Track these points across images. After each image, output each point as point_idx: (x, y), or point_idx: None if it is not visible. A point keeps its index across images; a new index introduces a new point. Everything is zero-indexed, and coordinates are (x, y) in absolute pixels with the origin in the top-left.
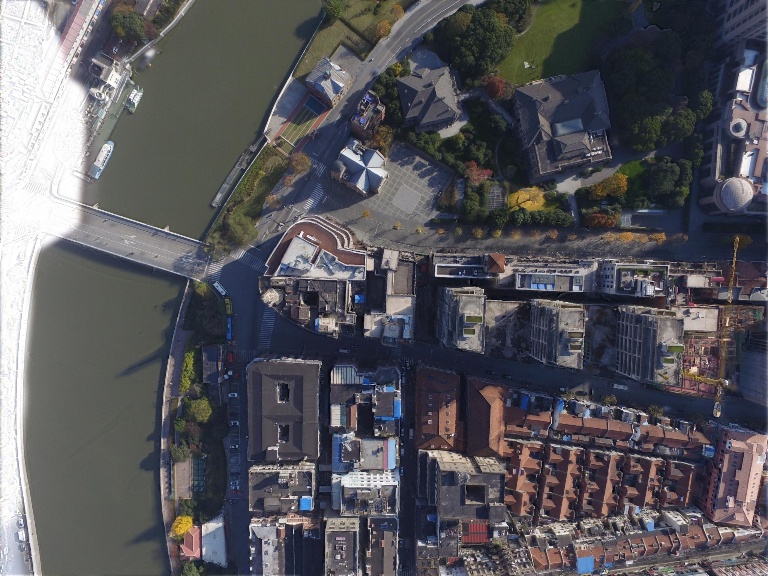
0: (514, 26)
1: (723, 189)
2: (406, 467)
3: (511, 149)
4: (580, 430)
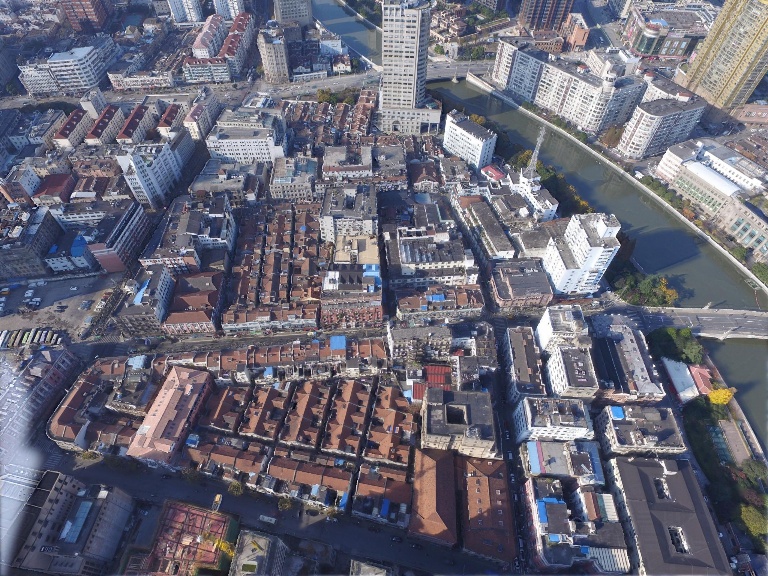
0: None
1: None
2: (504, 439)
3: None
4: (326, 471)
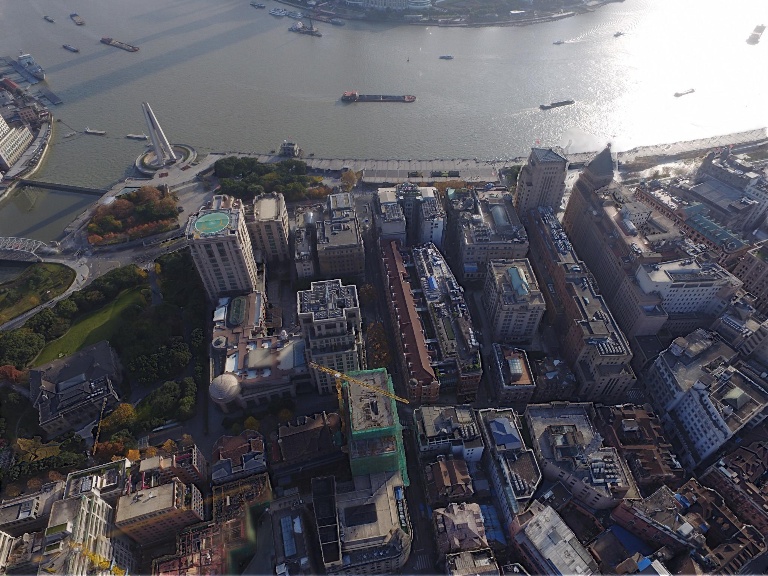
0: (47, 334)
1: (210, 386)
2: None
3: (31, 417)
4: None
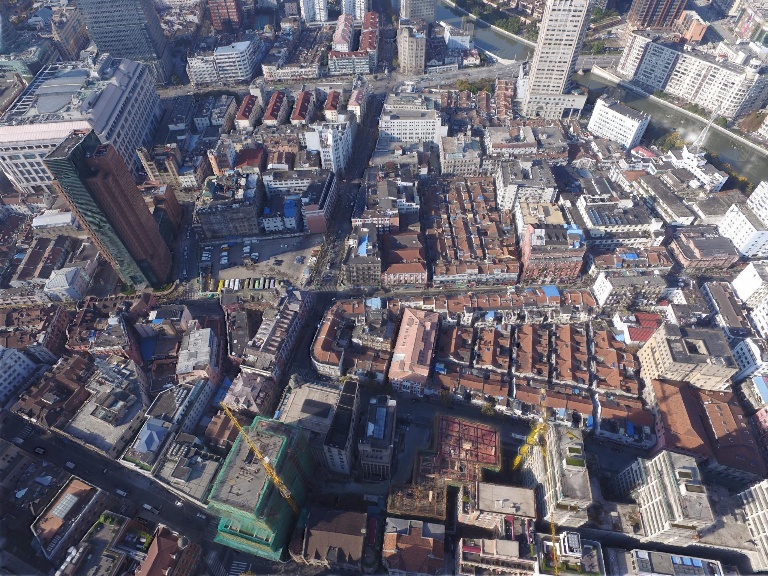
0: None
1: None
2: None
3: None
4: (567, 397)
